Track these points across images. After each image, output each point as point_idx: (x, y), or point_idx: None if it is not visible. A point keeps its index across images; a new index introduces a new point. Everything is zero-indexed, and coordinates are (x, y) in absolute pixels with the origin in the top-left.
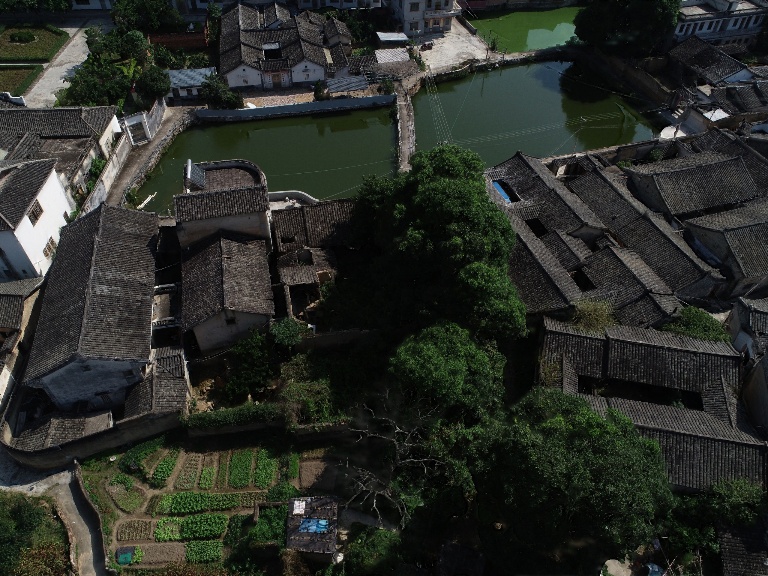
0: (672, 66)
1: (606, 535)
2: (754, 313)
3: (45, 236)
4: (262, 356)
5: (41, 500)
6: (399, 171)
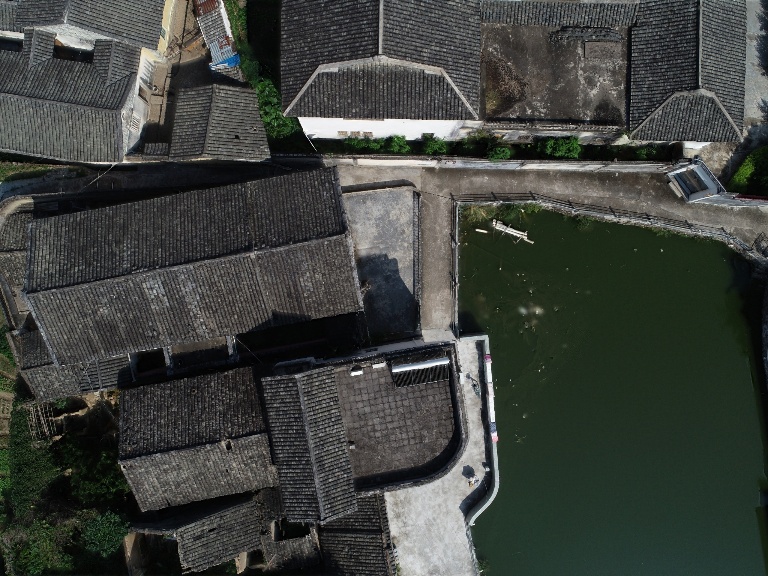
0: None
1: None
2: None
3: (359, 128)
4: (88, 494)
5: None
6: None
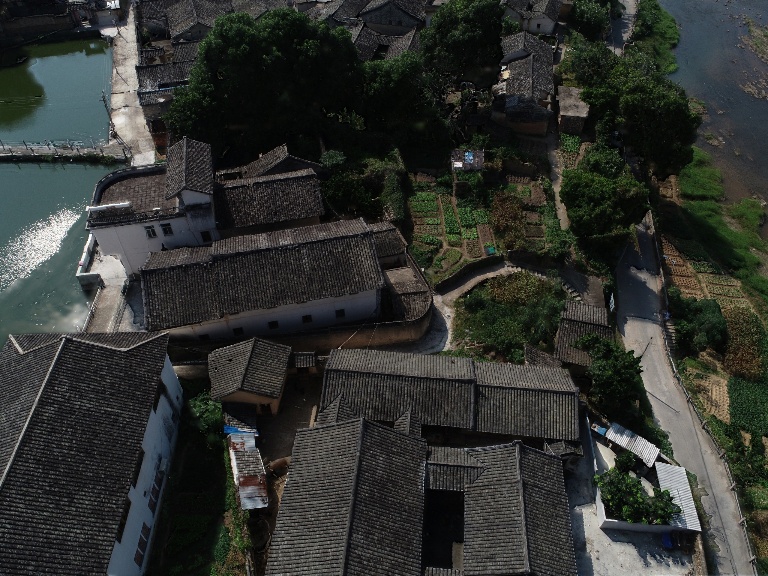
0: (14, 12)
1: (504, 10)
2: (333, 17)
3: None
4: None
5: (459, 301)
6: (91, 152)
